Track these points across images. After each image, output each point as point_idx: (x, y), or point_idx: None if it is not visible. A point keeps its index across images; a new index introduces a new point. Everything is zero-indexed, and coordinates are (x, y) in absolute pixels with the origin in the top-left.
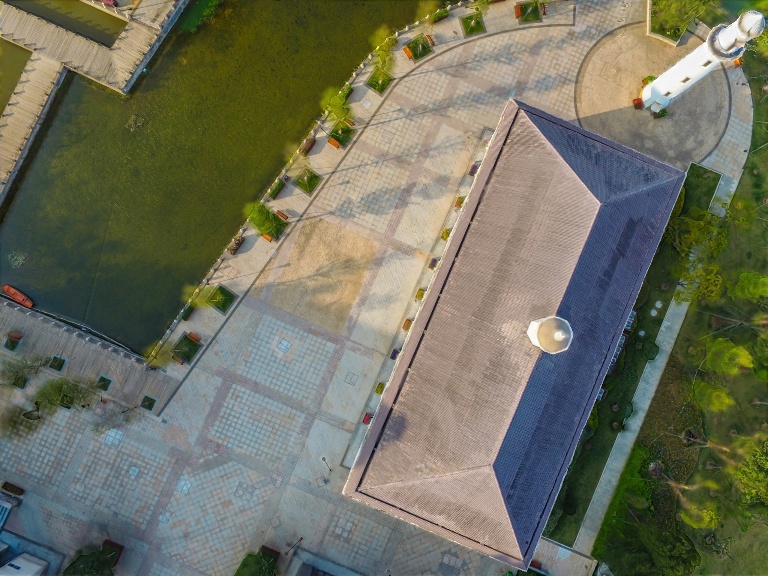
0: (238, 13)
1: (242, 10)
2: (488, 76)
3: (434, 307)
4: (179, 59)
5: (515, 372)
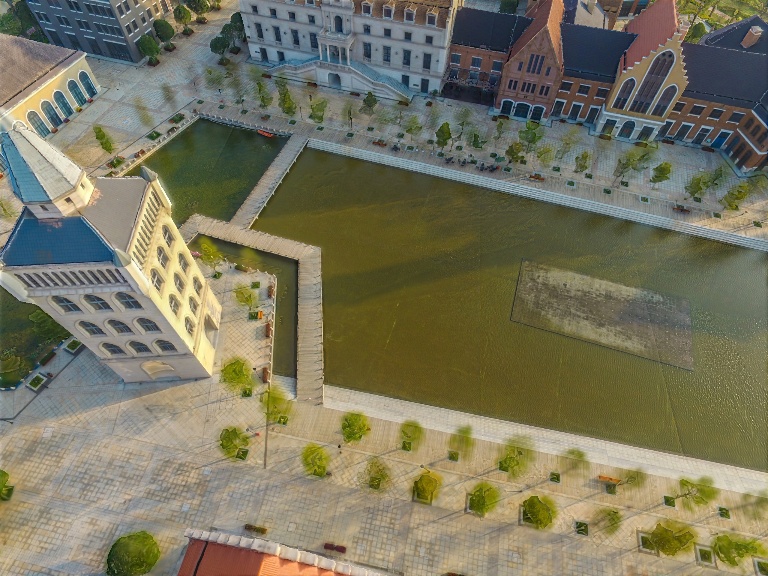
0: None
1: None
2: None
3: (14, 97)
4: None
5: None
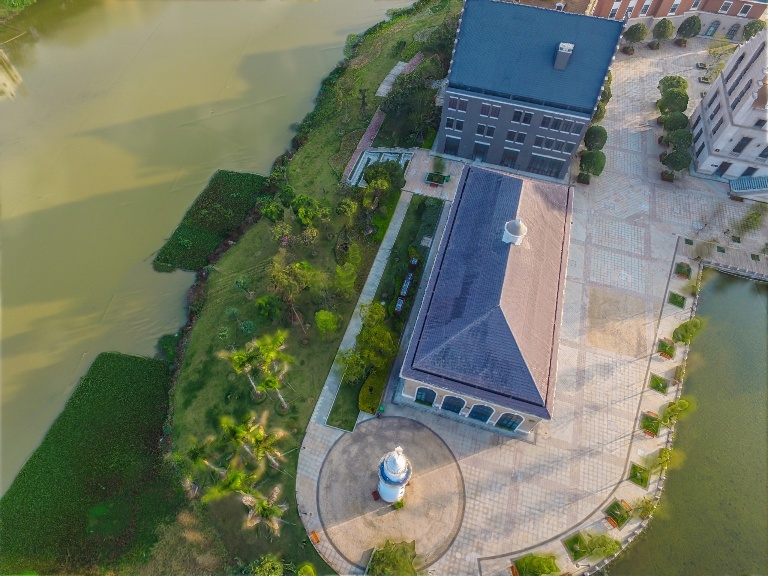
0: None
1: None
2: (546, 493)
3: (560, 273)
4: None
5: (522, 221)
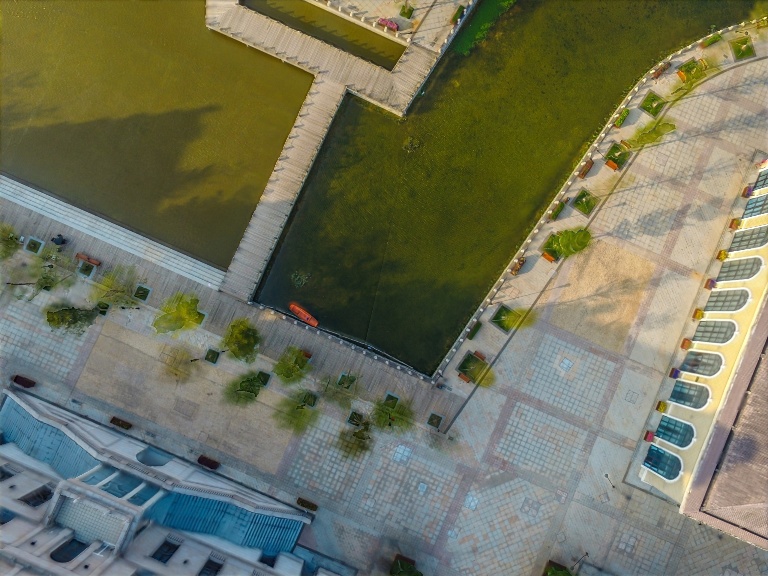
0: (508, 36)
1: (512, 33)
2: (758, 99)
3: None
4: (452, 82)
5: None
